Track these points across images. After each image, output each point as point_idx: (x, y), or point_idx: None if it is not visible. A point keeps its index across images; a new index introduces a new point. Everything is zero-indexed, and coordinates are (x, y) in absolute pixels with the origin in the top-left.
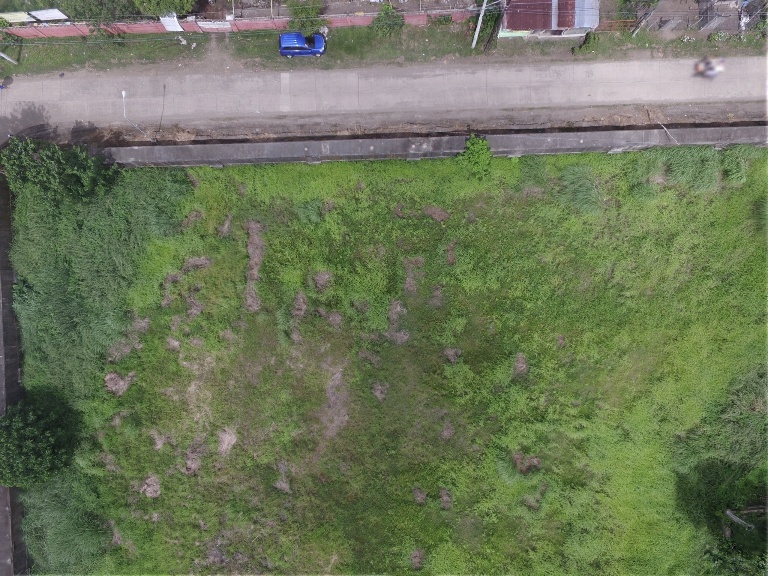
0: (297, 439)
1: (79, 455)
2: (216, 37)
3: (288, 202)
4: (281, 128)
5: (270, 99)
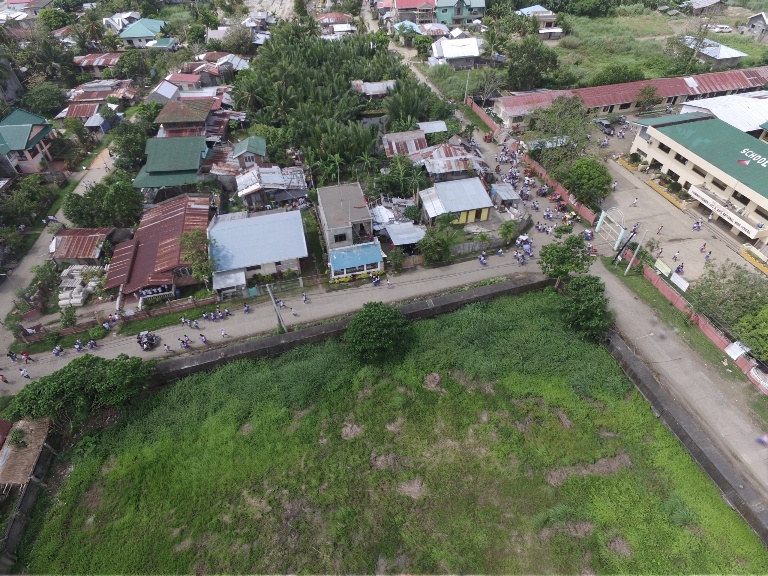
0: (439, 570)
1: (368, 369)
2: (751, 385)
3: (670, 486)
4: (728, 460)
5: (743, 443)
